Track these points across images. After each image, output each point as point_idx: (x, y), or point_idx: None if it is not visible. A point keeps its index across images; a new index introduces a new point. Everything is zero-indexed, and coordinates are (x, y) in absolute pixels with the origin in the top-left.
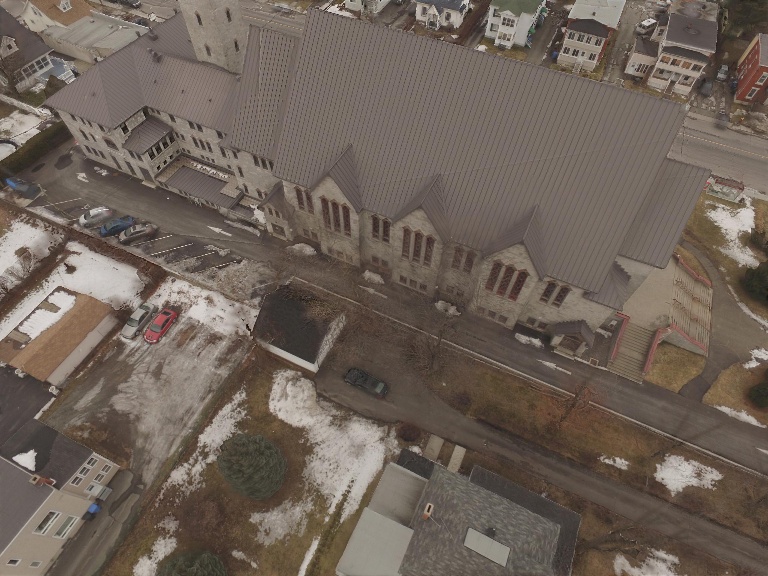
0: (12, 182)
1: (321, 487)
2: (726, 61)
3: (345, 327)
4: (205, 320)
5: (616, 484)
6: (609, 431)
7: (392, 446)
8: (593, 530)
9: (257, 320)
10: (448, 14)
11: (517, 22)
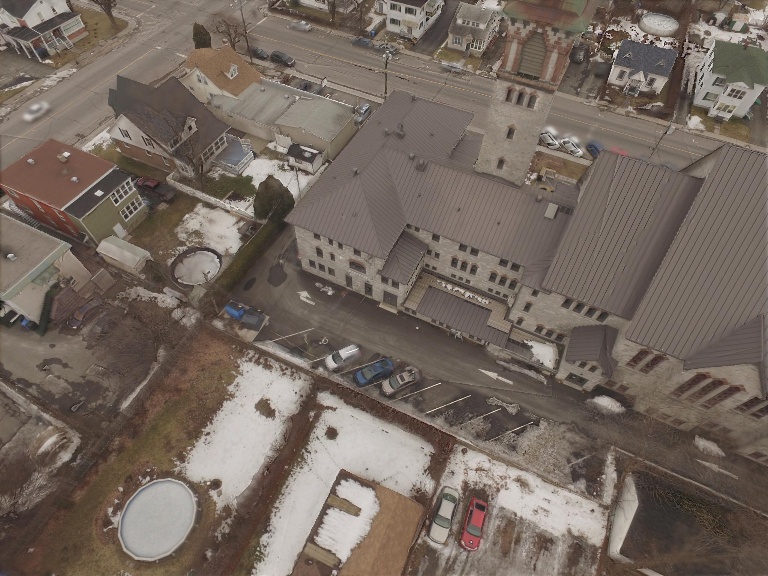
0: (234, 310)
1: None
2: None
3: None
4: (523, 512)
5: None
6: None
7: None
8: None
9: (628, 535)
10: (652, 79)
11: None
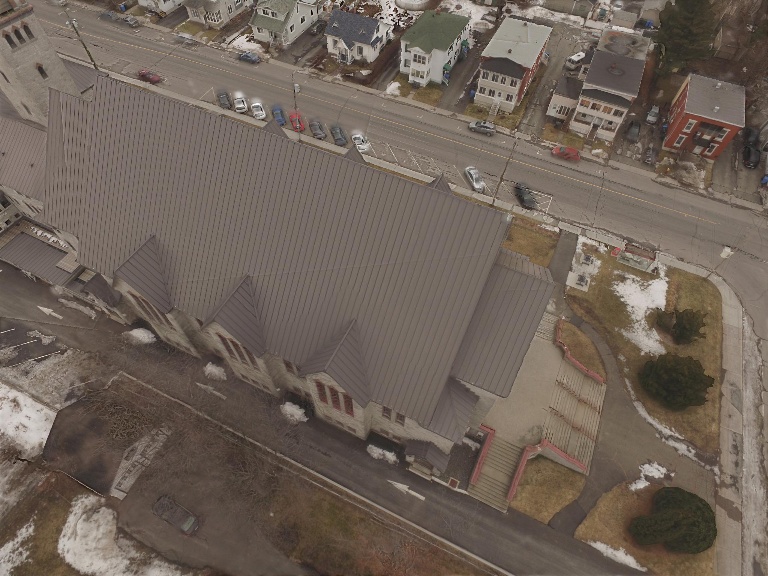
0: None
1: None
2: (659, 100)
3: (170, 437)
4: (7, 429)
5: None
6: None
7: None
8: None
9: (47, 440)
10: (360, 48)
11: (429, 59)
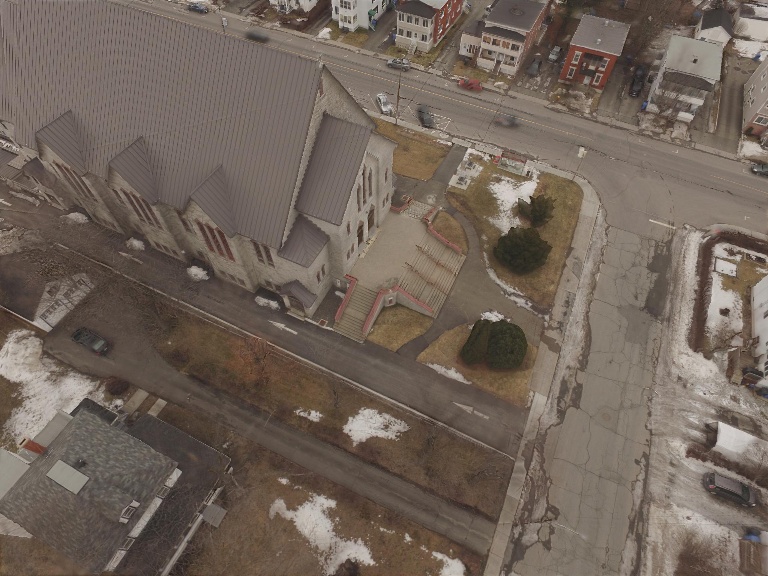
0: None
1: (17, 437)
2: None
3: (93, 290)
4: None
5: (302, 435)
6: (314, 386)
7: (97, 399)
8: (262, 476)
9: None
10: None
11: (354, 4)
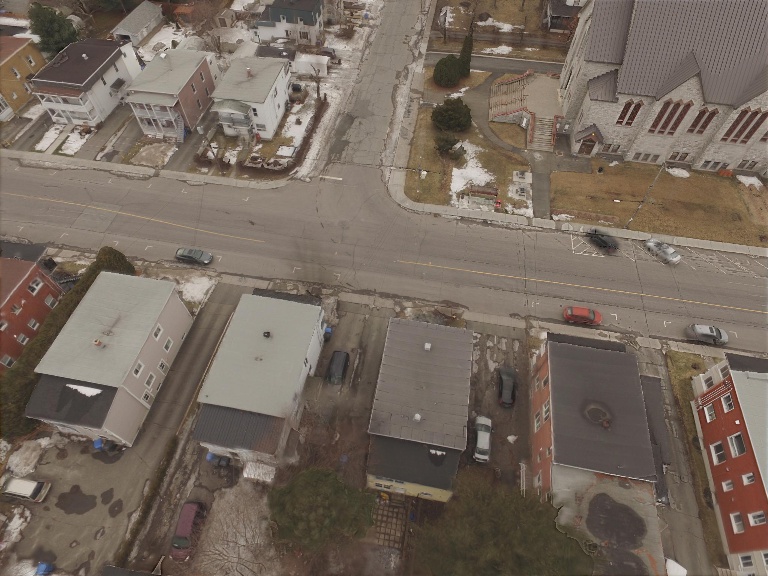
0: None
1: None
2: None
3: None
4: None
5: (529, 43)
6: None
7: None
8: (536, 32)
9: None
10: None
11: None
